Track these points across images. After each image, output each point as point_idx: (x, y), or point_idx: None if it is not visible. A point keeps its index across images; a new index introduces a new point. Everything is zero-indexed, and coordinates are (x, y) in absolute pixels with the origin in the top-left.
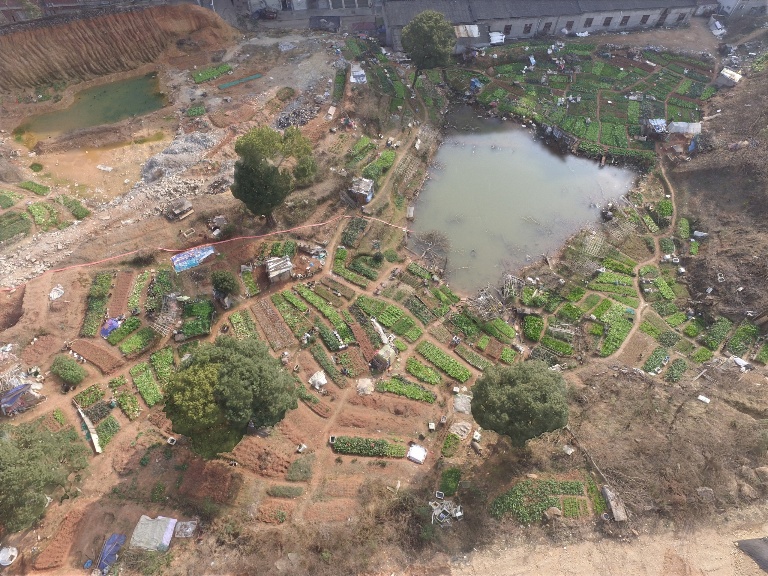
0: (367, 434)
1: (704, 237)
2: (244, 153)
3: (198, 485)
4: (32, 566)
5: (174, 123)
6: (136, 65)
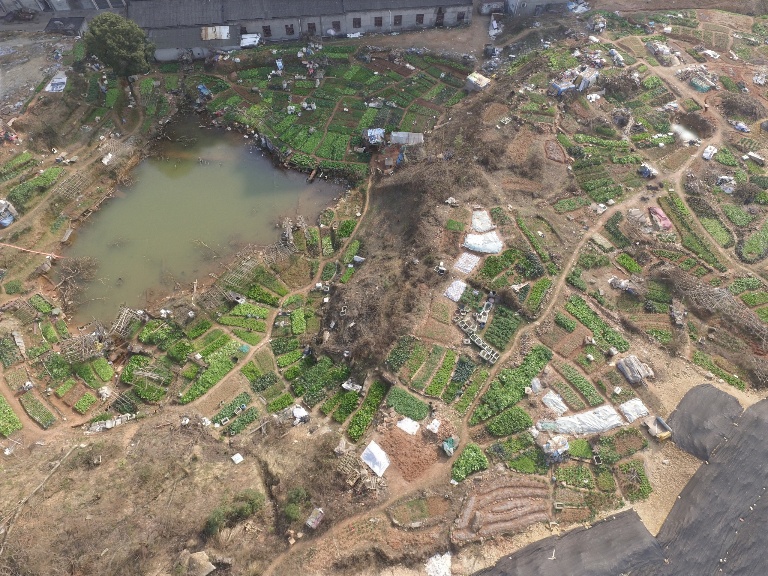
0: None
1: (360, 262)
2: None
3: None
4: None
5: None
6: None
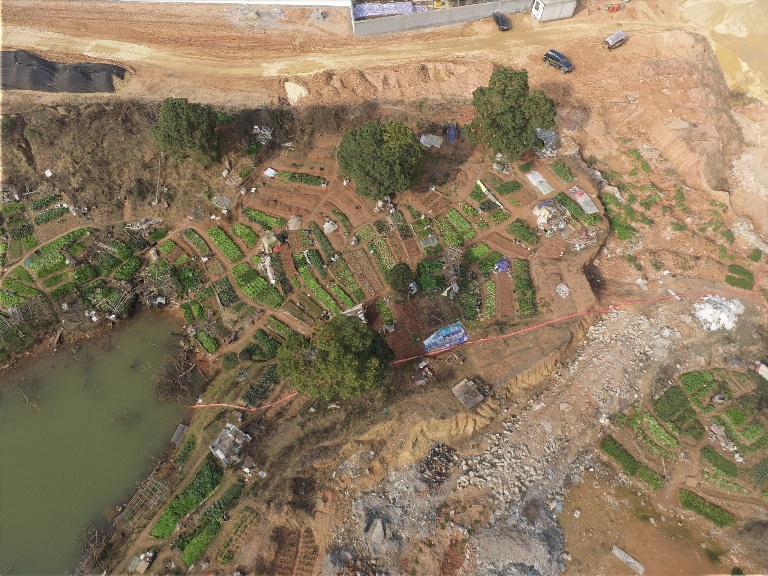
0: (300, 186)
1: None
2: None
3: None
4: None
5: None
6: None
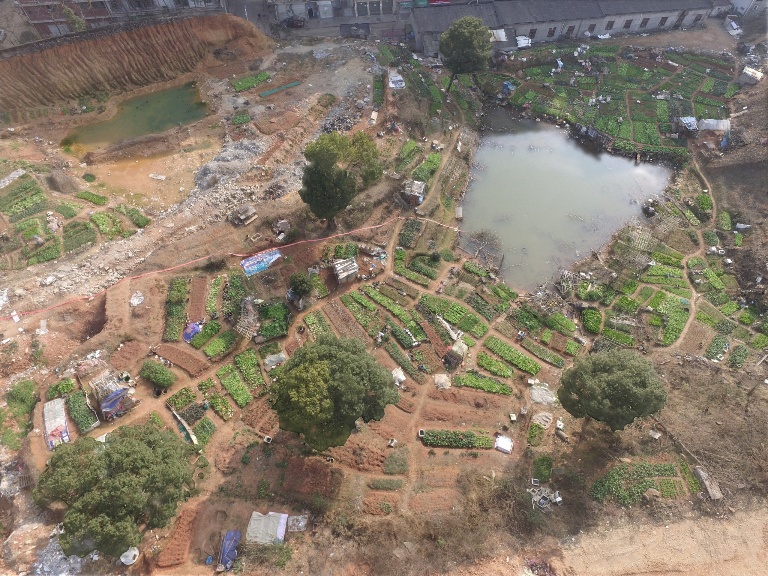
0: (453, 427)
1: (747, 229)
2: (318, 158)
3: (300, 481)
4: (155, 564)
5: (220, 131)
6: (175, 75)
